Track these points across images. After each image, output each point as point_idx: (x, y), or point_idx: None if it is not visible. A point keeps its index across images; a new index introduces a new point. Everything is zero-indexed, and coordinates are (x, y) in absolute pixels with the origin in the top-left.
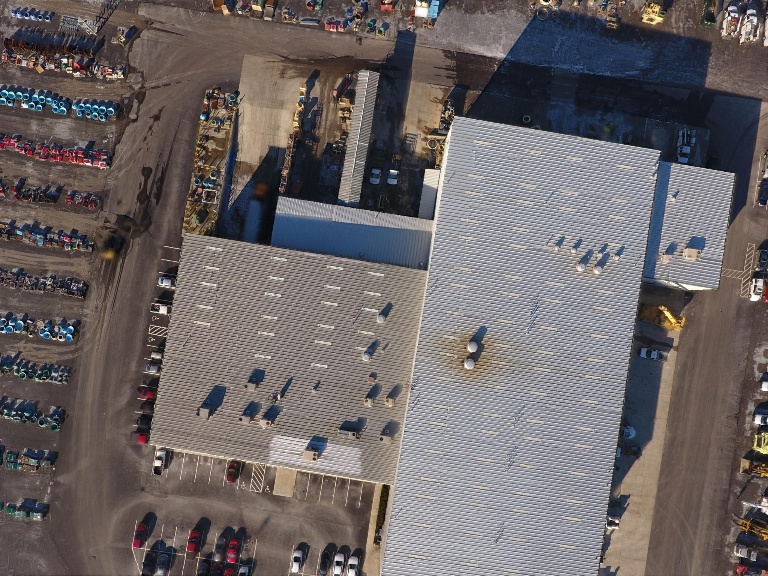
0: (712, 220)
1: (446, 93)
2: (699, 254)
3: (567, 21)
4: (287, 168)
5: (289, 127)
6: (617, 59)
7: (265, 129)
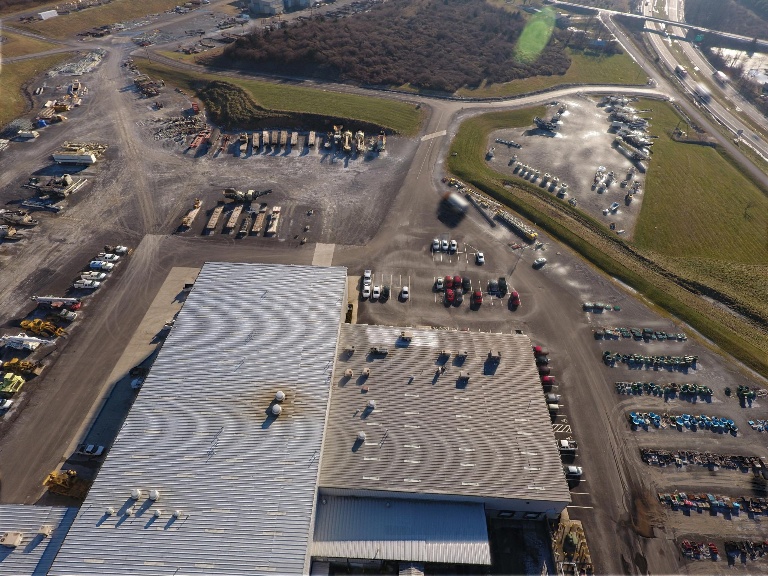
0: None
1: None
2: (3, 538)
3: None
4: None
5: None
6: None
7: None
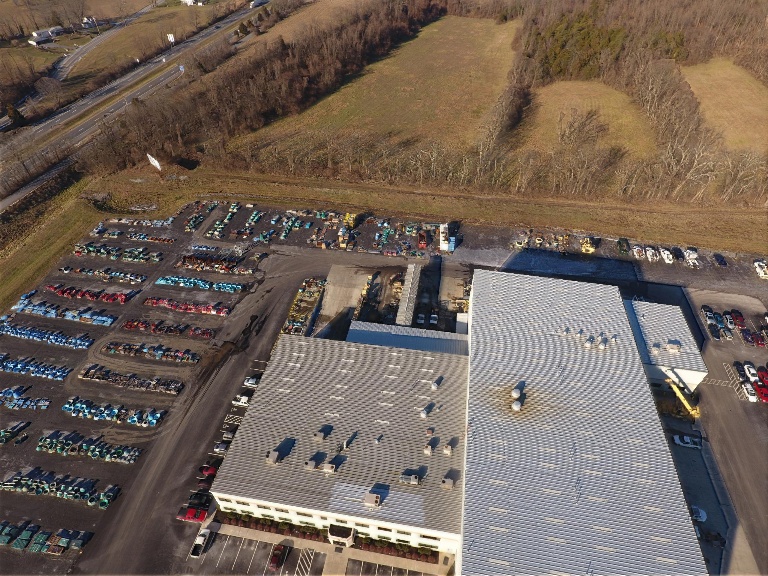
0: (678, 331)
1: None
2: (679, 347)
3: (536, 253)
4: (358, 310)
5: None
6: (574, 268)
7: (342, 298)
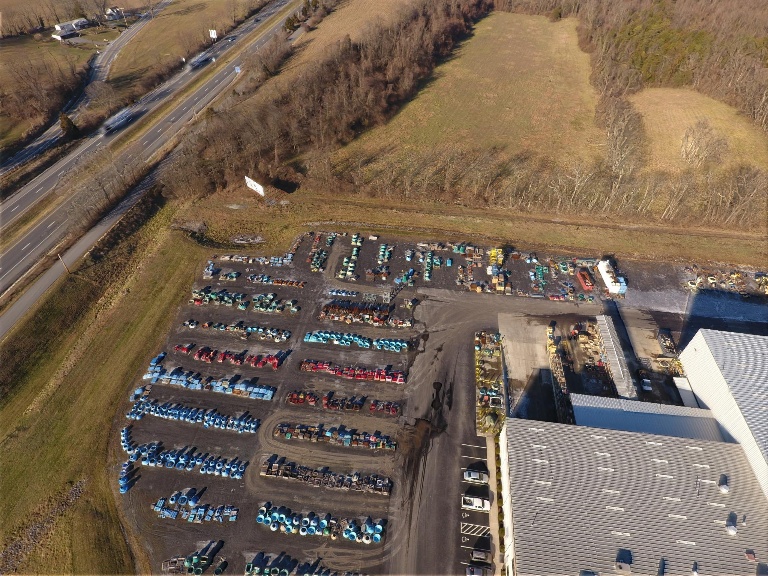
0: None
1: (655, 333)
2: None
3: (714, 295)
4: (563, 377)
5: (544, 355)
6: (764, 313)
7: (526, 356)
